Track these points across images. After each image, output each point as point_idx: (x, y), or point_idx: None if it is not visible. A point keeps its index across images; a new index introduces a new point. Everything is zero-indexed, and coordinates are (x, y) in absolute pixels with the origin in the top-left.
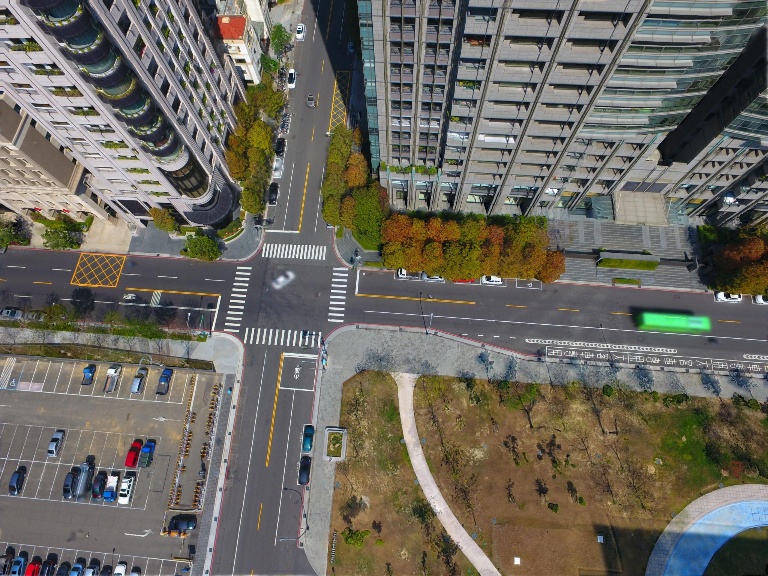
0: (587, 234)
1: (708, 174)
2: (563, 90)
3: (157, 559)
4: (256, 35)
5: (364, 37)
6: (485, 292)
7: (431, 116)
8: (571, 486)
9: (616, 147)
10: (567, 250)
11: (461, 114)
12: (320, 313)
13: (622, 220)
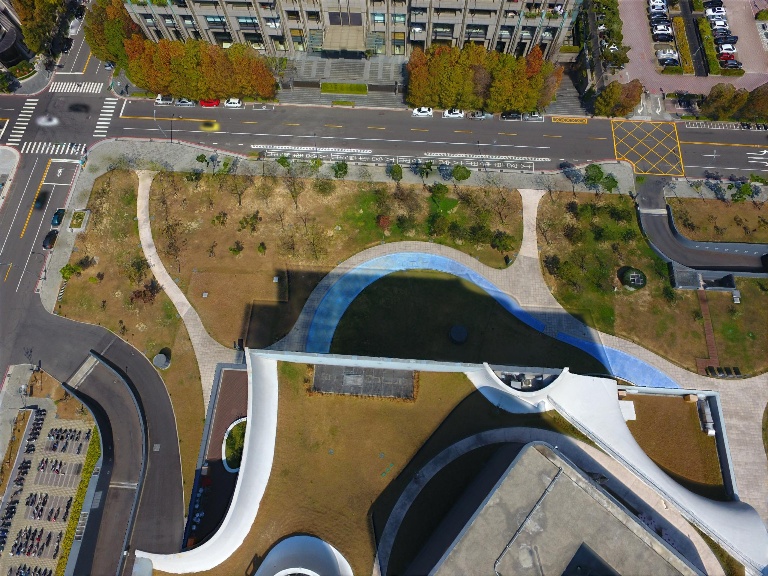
0: (318, 70)
1: None
2: None
3: None
4: None
5: None
6: (226, 113)
7: None
8: (262, 245)
9: None
10: None
11: None
12: (88, 130)
13: (328, 46)
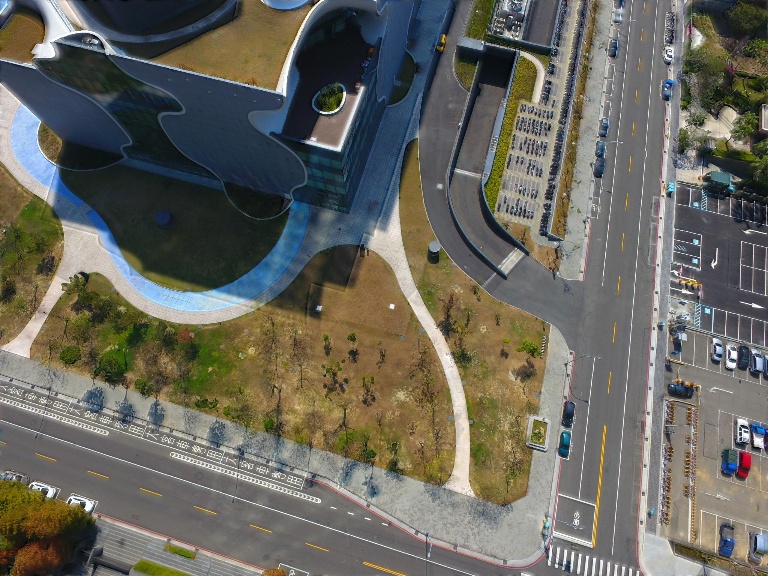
0: None
1: None
2: None
3: (699, 367)
4: None
5: None
6: (348, 575)
7: None
8: (327, 352)
9: None
10: None
11: None
12: None
13: None
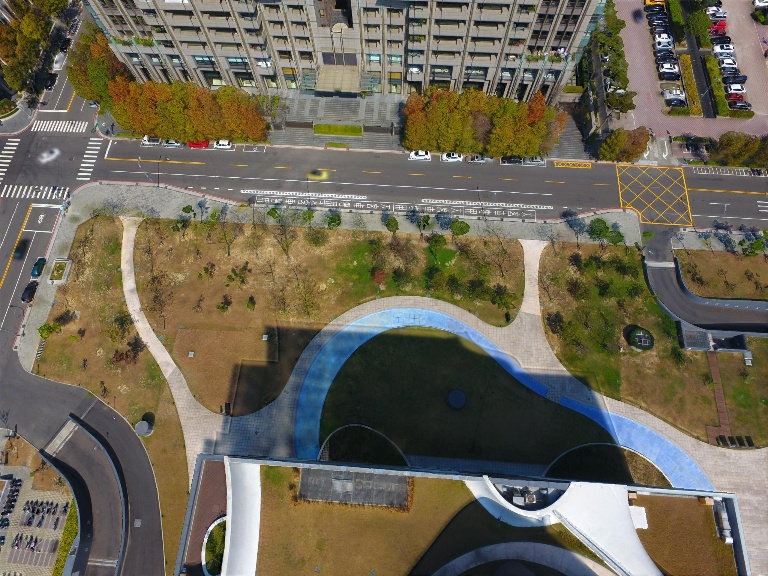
0: (312, 109)
1: (379, 41)
2: None
3: None
4: None
5: None
6: (215, 155)
7: None
8: (252, 299)
9: (283, 10)
10: None
11: None
12: (71, 173)
13: (321, 87)
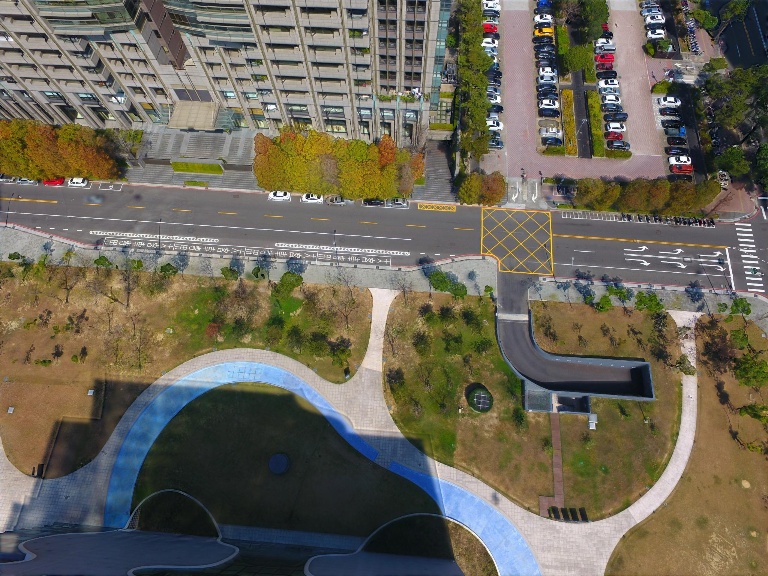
0: (175, 145)
1: None
2: None
3: None
4: None
5: None
6: (69, 193)
7: None
8: (84, 350)
9: (117, 48)
10: (153, 158)
11: None
12: None
13: (174, 124)
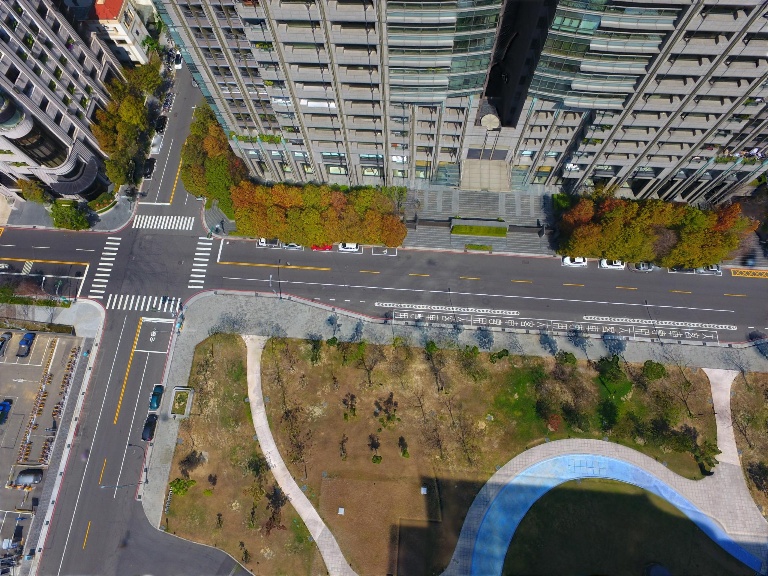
0: (445, 203)
1: (540, 139)
2: (354, 51)
3: (1, 511)
4: (140, 17)
5: (155, 1)
6: (341, 259)
7: (254, 82)
8: (402, 441)
9: (439, 112)
10: (424, 218)
11: (271, 77)
12: (181, 280)
13: (466, 186)
